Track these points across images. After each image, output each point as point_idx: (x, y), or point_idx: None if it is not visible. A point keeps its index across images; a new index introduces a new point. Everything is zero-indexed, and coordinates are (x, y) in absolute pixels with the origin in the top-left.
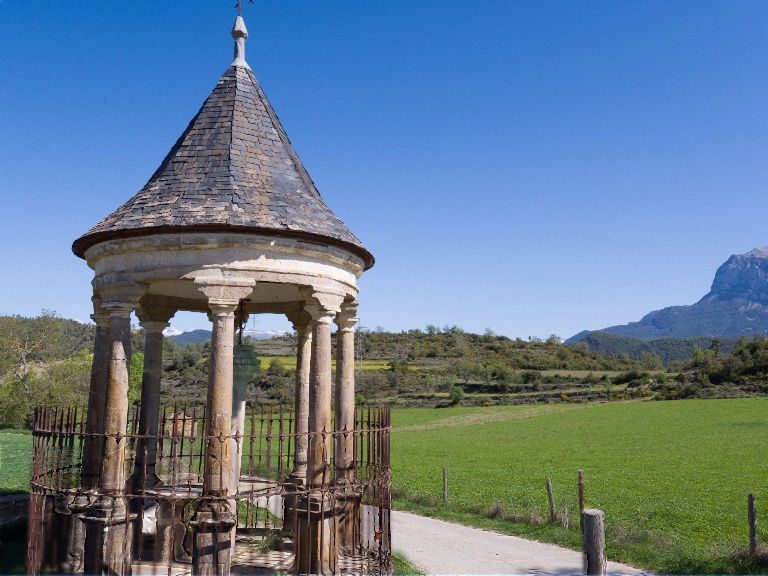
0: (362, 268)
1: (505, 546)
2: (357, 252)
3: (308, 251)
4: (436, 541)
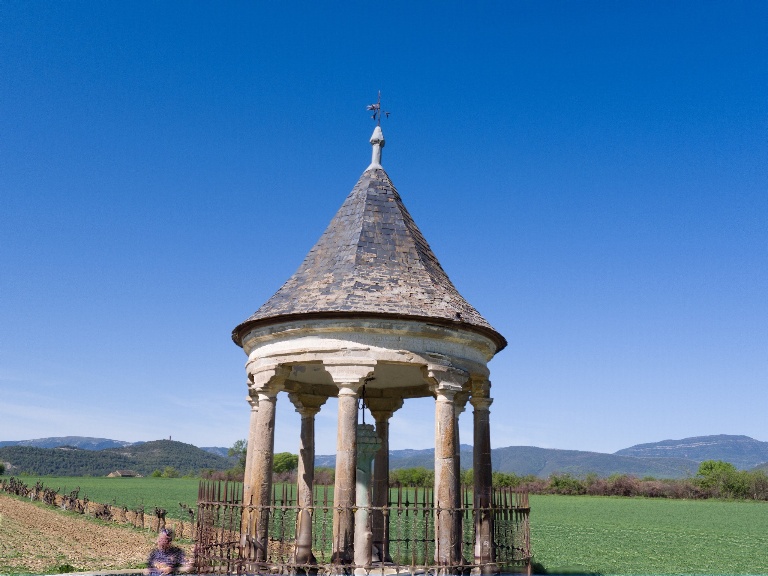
0: (311, 326)
1: None
2: (277, 320)
3: (249, 343)
4: None
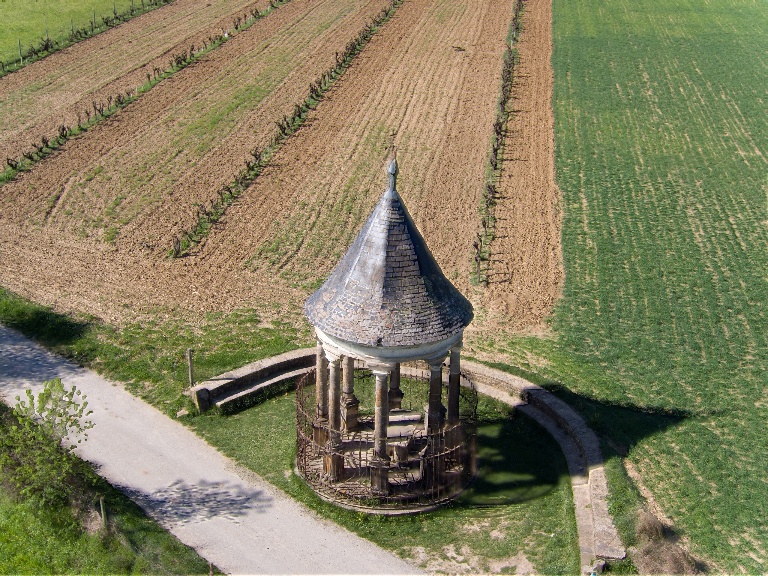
0: None
1: (270, 571)
2: None
3: None
4: (329, 575)
